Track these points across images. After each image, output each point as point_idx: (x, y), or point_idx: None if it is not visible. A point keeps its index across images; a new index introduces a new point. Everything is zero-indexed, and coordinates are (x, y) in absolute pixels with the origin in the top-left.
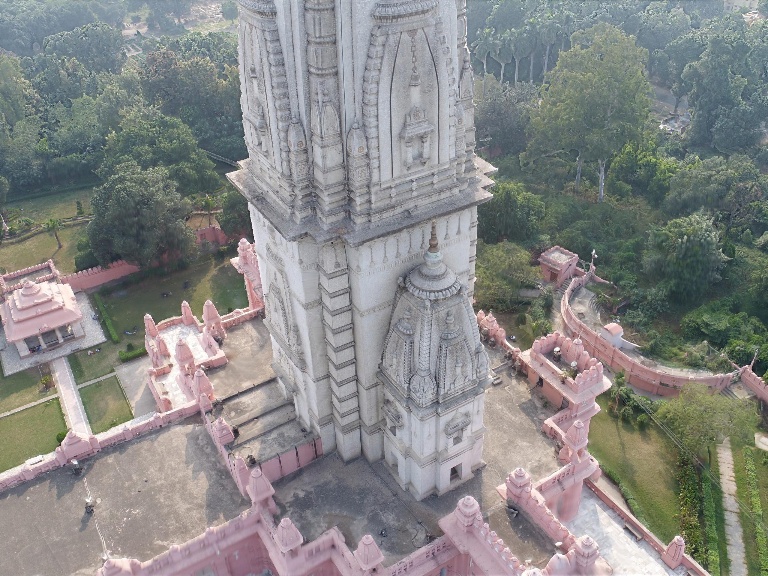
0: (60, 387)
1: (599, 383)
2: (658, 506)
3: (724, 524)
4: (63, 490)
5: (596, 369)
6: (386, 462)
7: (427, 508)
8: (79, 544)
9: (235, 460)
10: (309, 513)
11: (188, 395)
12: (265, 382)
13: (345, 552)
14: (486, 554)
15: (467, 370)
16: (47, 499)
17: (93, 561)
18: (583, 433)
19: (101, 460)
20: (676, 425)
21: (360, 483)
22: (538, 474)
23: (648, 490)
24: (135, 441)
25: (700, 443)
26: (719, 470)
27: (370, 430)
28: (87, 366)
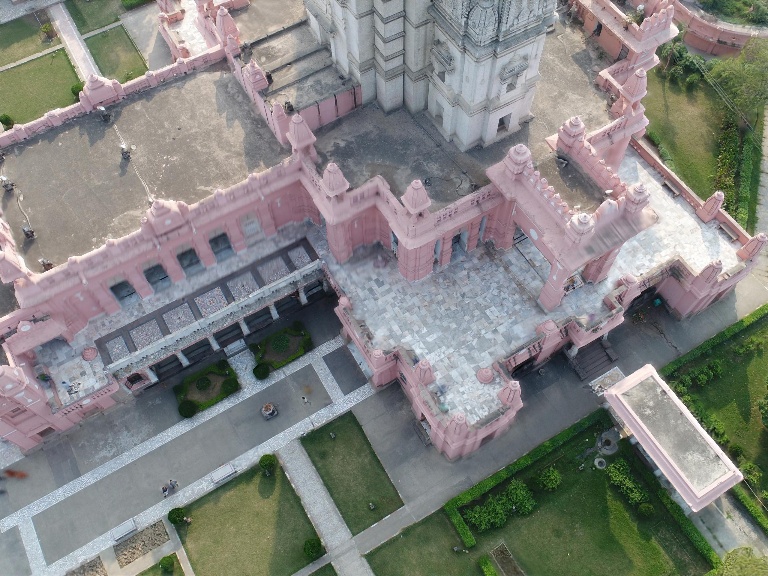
0: (63, 37)
1: (666, 30)
2: (695, 167)
3: (758, 185)
4: (95, 137)
5: (666, 13)
6: (429, 113)
7: (472, 159)
8: (122, 188)
9: (273, 106)
10: (351, 162)
11: (210, 40)
12: (295, 25)
13: (390, 198)
14: (533, 201)
15: (534, 2)
16: (80, 145)
17: (139, 204)
18: (644, 83)
19: (128, 107)
20: (730, 84)
21: (402, 134)
22: (588, 127)
23: (687, 152)
24: (161, 88)
25: (754, 102)
26: (763, 133)
27: (415, 76)
28: (88, 14)
